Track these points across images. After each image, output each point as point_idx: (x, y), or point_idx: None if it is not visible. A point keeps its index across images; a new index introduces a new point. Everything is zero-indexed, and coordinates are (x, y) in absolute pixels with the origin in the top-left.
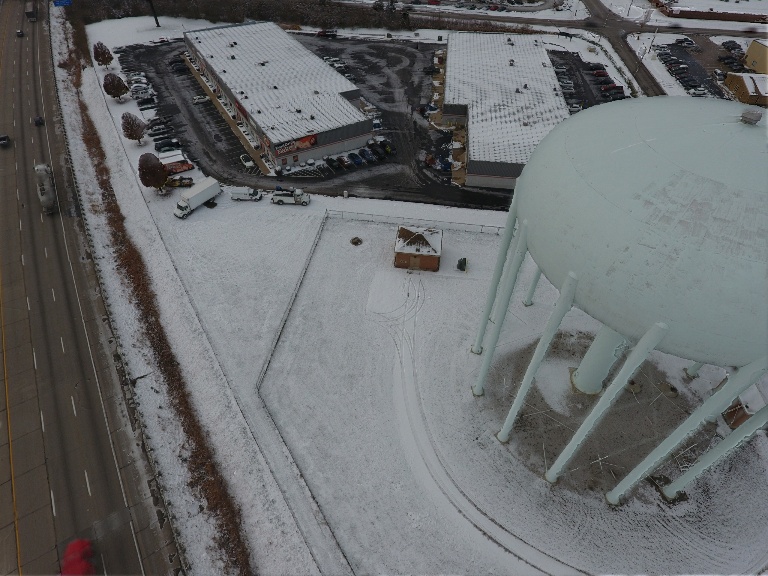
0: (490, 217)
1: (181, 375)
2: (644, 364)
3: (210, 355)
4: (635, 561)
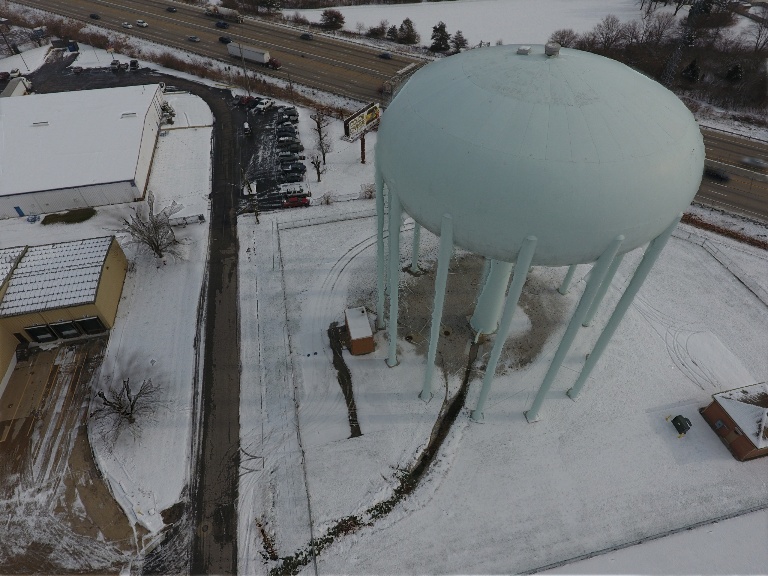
0: (737, 575)
1: (763, 249)
2: (436, 357)
3: (765, 257)
4: (433, 235)
